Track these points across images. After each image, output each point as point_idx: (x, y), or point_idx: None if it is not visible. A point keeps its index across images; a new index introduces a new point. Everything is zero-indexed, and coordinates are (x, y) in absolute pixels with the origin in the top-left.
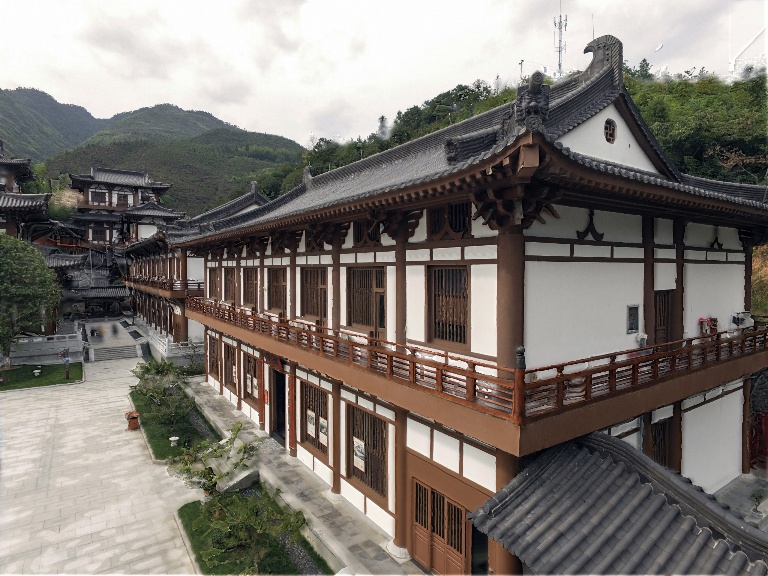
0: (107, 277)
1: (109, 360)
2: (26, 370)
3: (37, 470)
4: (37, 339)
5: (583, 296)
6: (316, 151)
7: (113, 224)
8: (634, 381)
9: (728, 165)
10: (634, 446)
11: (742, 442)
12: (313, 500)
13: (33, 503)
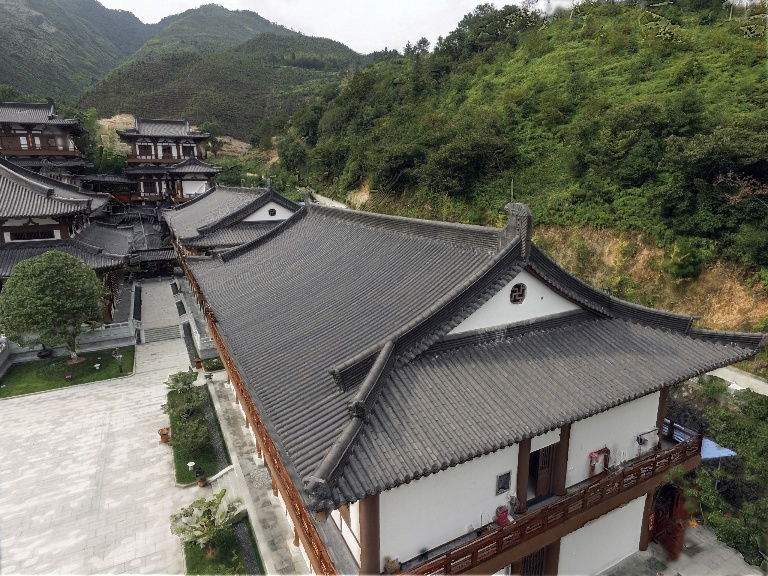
0: (159, 233)
1: (157, 342)
2: (89, 363)
3: (92, 489)
4: (97, 328)
5: (444, 487)
6: (352, 86)
7: (161, 176)
8: (473, 561)
9: (733, 200)
10: (502, 569)
11: (642, 526)
12: (279, 550)
13: (88, 526)
